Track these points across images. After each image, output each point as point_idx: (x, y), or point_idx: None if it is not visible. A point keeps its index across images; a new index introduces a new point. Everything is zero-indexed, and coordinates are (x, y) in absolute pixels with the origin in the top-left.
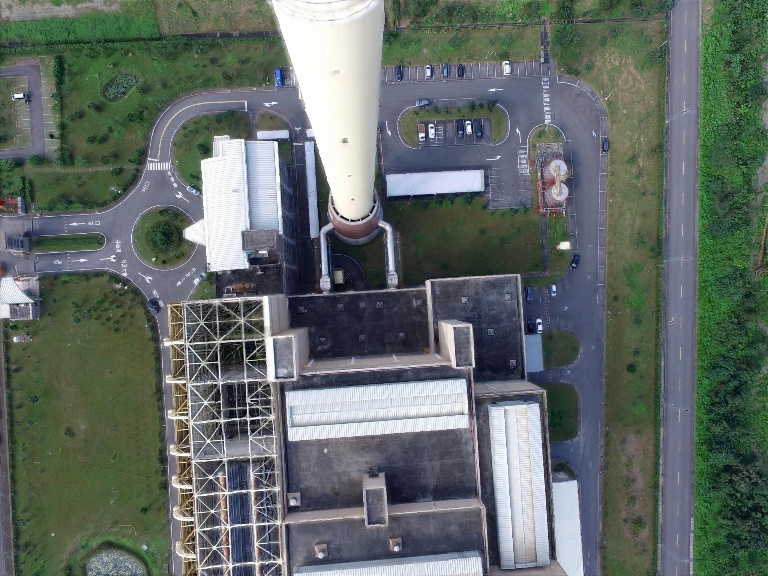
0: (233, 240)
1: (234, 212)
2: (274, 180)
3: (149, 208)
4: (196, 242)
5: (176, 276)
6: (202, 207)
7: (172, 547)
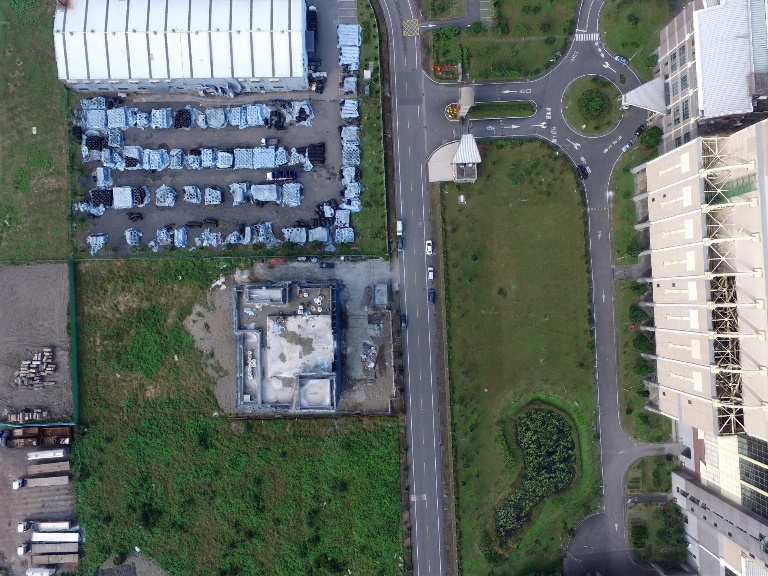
0: (737, 85)
1: (738, 58)
2: (765, 31)
3: (578, 77)
4: (637, 106)
5: (603, 143)
6: (628, 77)
7: (599, 406)
